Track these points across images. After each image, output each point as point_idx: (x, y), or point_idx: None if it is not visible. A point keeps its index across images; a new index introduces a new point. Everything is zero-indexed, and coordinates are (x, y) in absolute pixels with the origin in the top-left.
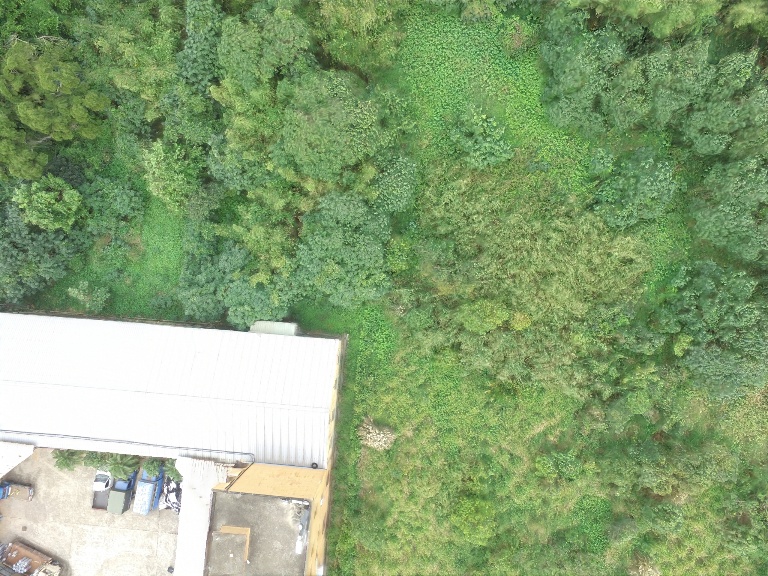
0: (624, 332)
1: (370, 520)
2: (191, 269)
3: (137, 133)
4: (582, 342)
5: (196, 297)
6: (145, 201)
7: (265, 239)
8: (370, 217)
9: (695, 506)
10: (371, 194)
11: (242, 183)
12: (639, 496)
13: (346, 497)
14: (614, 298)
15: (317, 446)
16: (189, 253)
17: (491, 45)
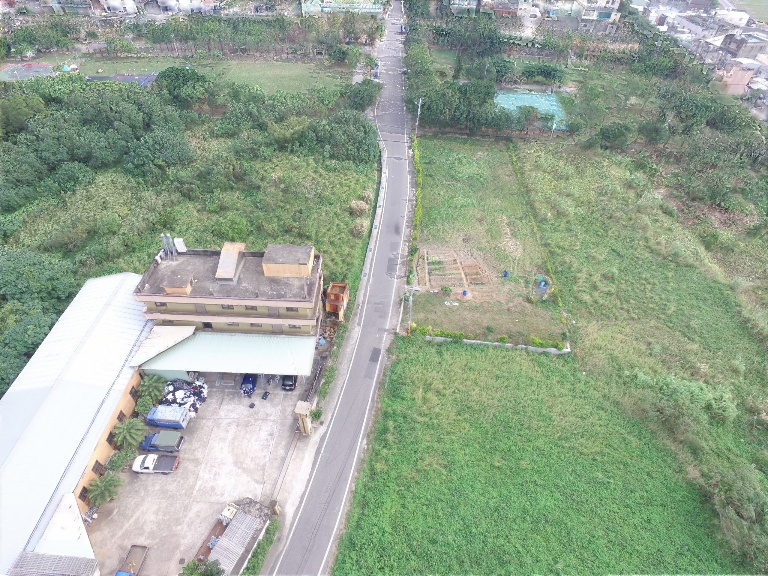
0: None
1: None
2: None
3: None
4: None
5: (1, 366)
6: None
7: None
8: (6, 255)
9: None
10: None
11: None
12: None
13: None
14: None
15: None
16: None
17: None
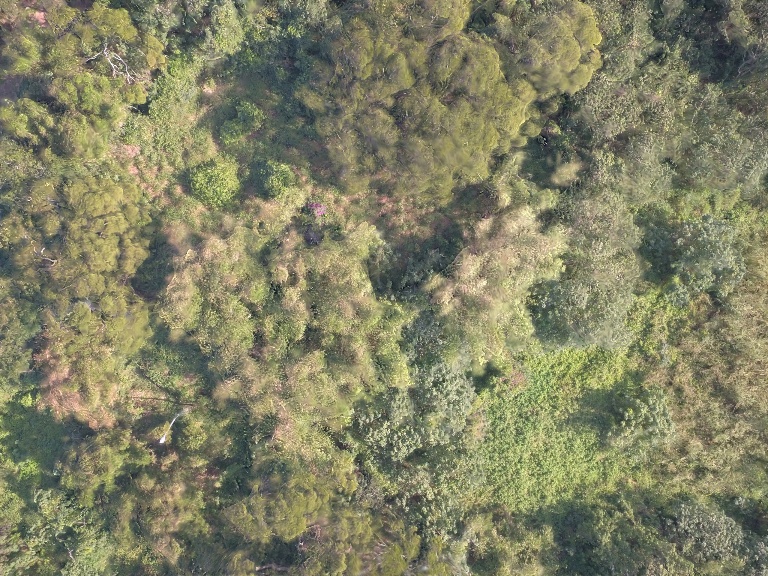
0: None
1: None
2: None
3: None
4: None
5: None
6: None
7: None
8: (762, 565)
9: None
10: (735, 564)
11: None
12: None
13: None
14: None
15: None
16: None
17: (513, 404)
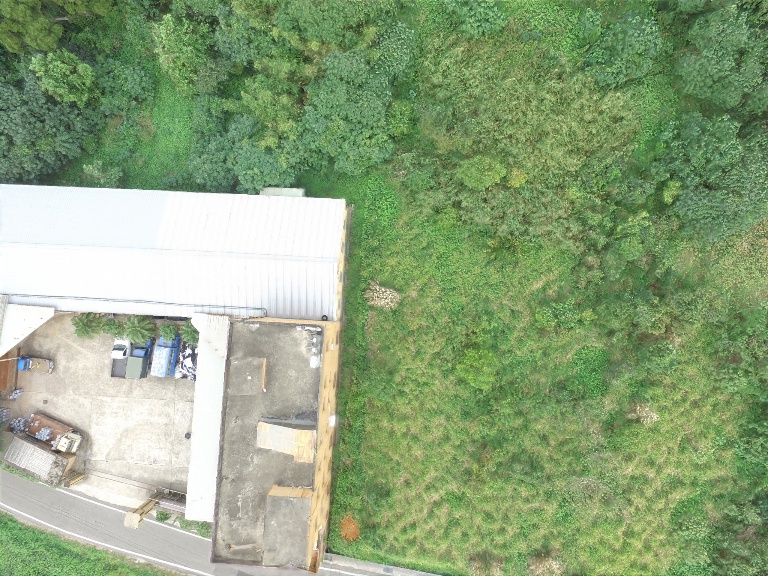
0: (616, 182)
1: (379, 372)
2: (201, 144)
3: (146, 15)
4: (577, 196)
5: (207, 164)
6: (155, 84)
7: (272, 105)
8: (372, 76)
9: (688, 351)
10: (372, 54)
11: (249, 53)
12: (635, 344)
13: (355, 358)
14: (606, 153)
15: (327, 298)
16: (198, 132)
17: None
